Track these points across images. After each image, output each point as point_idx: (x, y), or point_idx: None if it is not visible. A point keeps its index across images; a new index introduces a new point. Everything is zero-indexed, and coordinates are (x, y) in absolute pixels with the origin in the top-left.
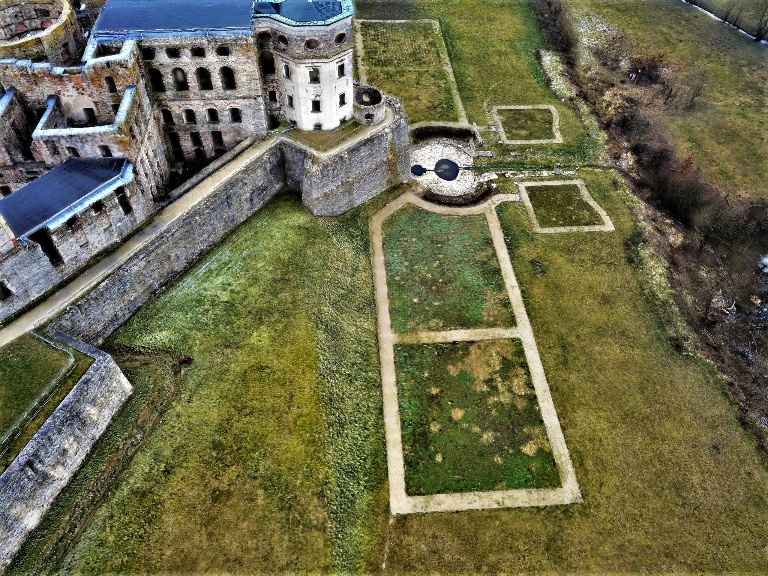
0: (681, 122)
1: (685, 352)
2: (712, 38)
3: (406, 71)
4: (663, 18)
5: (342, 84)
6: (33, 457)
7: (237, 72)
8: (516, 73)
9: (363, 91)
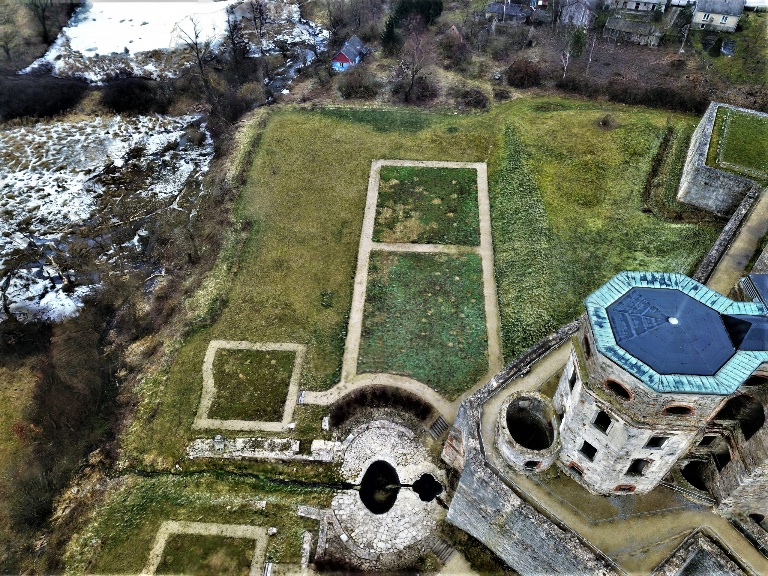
0: None
1: None
2: None
3: None
4: None
5: None
6: None
7: None
8: None
9: None
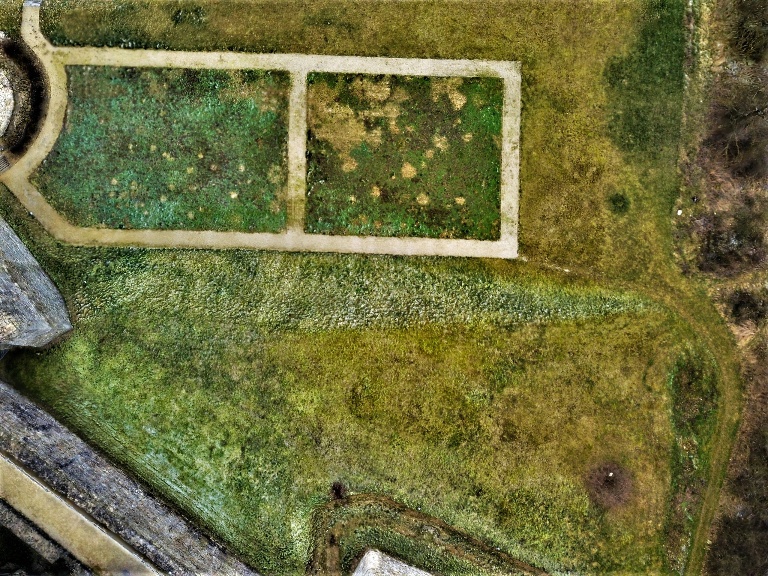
0: None
1: None
2: None
3: None
4: None
5: None
6: None
7: None
8: None
9: None
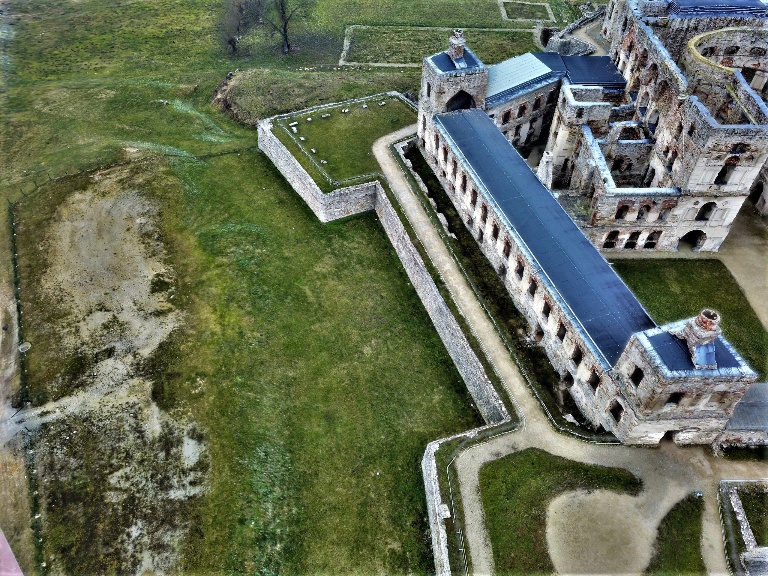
0: None
1: None
2: None
3: None
4: None
5: None
6: None
7: None
8: (453, 5)
9: None
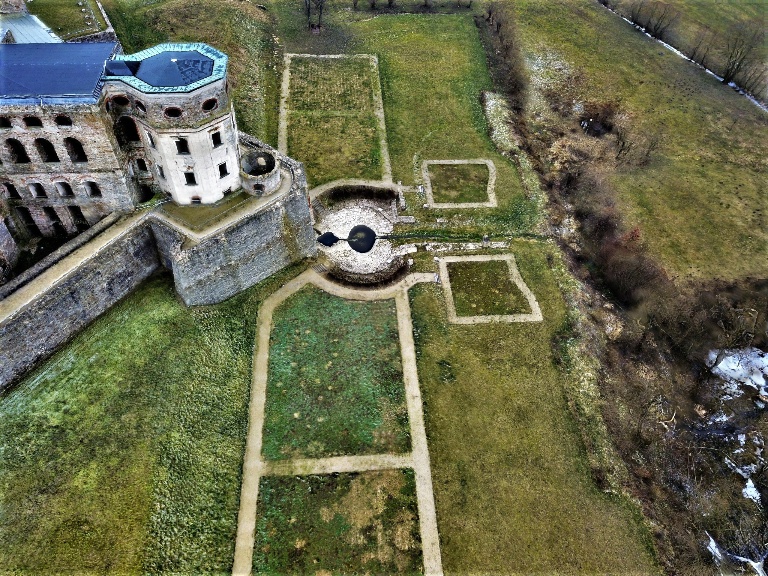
0: (632, 182)
1: (607, 489)
2: (676, 79)
3: (332, 116)
4: (625, 55)
5: (220, 153)
6: None
7: (85, 143)
8: (454, 120)
9: (257, 155)
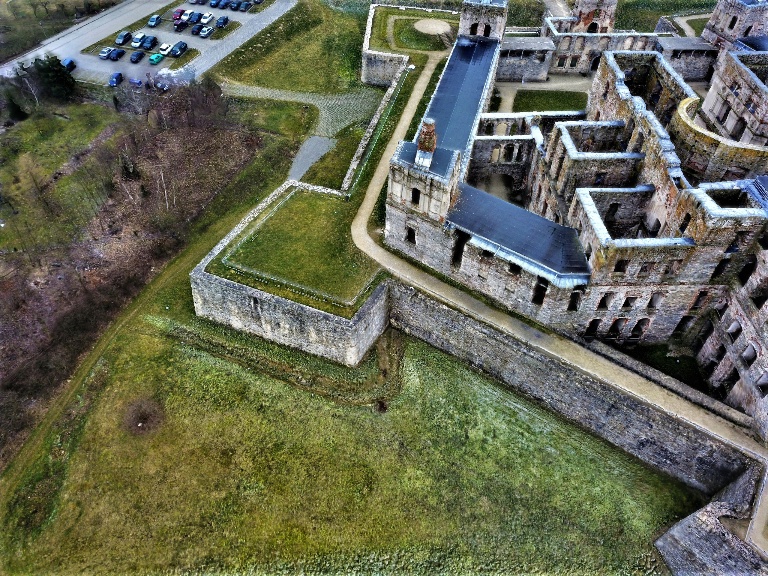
0: None
1: None
2: None
3: None
4: None
5: None
6: (259, 300)
7: None
8: None
9: None
